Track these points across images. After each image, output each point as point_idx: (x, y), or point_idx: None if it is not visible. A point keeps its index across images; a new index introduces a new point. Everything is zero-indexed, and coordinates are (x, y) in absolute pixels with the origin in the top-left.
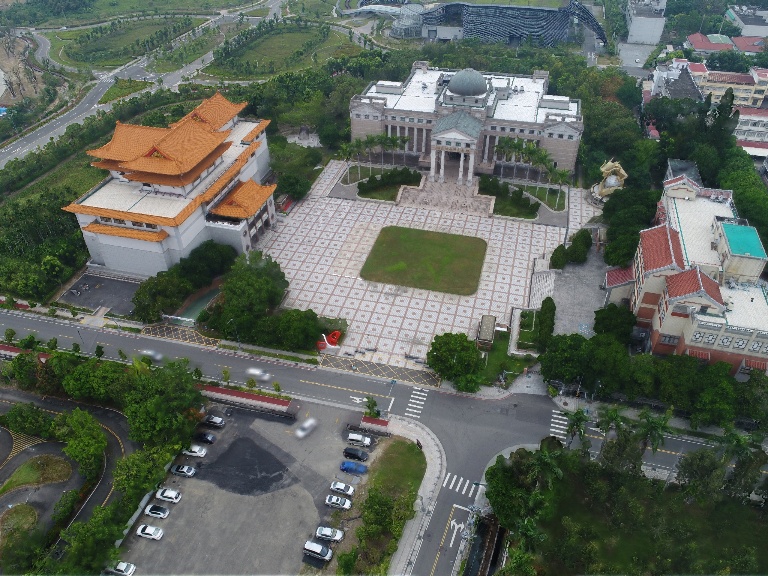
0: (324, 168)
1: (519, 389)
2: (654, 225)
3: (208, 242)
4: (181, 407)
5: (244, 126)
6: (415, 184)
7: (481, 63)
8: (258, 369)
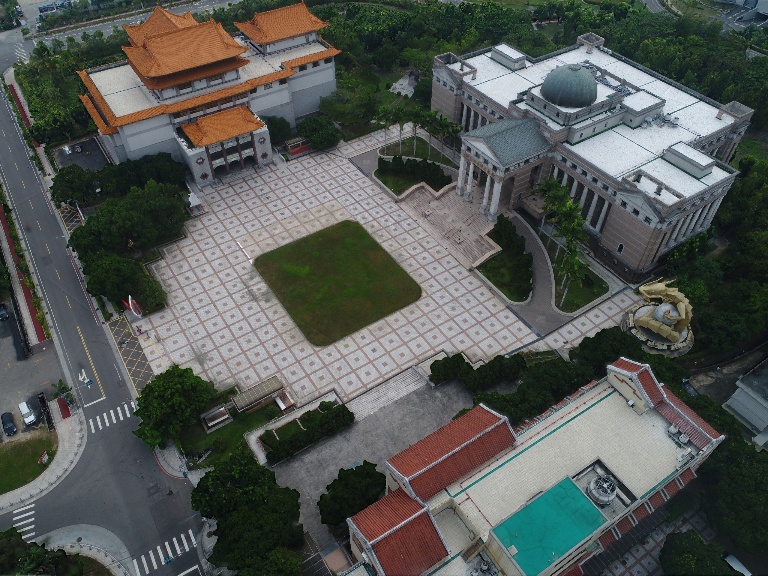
0: None
1: (197, 480)
2: None
3: (160, 154)
4: None
5: (312, 48)
6: (436, 187)
7: (724, 64)
8: (71, 294)
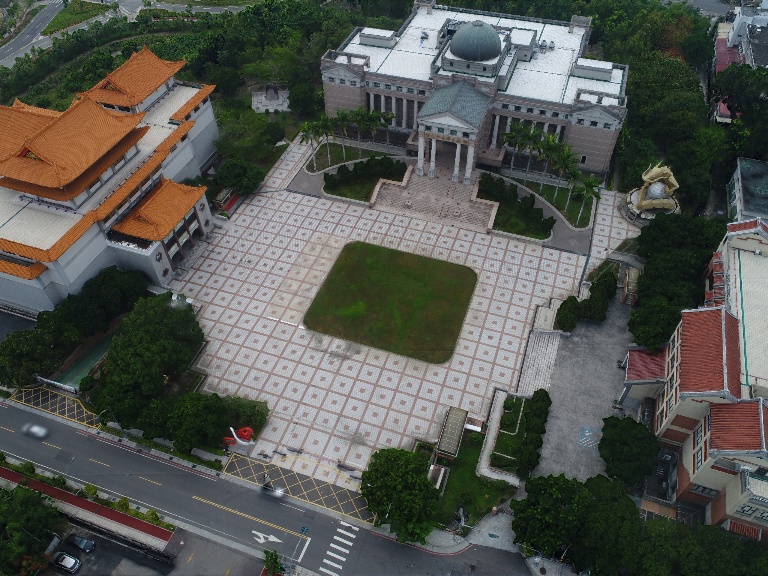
0: (289, 144)
1: (482, 538)
2: (705, 278)
3: (107, 271)
4: (7, 560)
5: (180, 93)
6: (397, 178)
7: None
8: (143, 472)
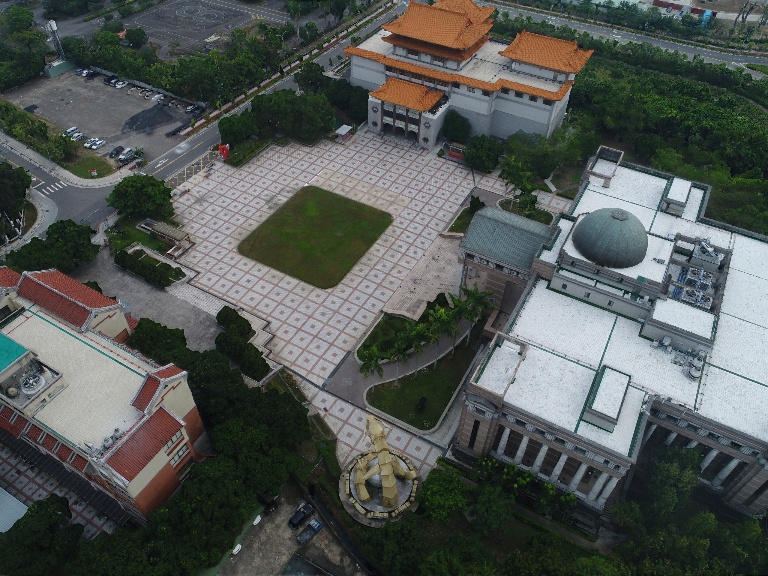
0: (551, 193)
1: (98, 237)
2: None
3: (364, 90)
4: None
5: (547, 85)
6: None
7: None
8: None
